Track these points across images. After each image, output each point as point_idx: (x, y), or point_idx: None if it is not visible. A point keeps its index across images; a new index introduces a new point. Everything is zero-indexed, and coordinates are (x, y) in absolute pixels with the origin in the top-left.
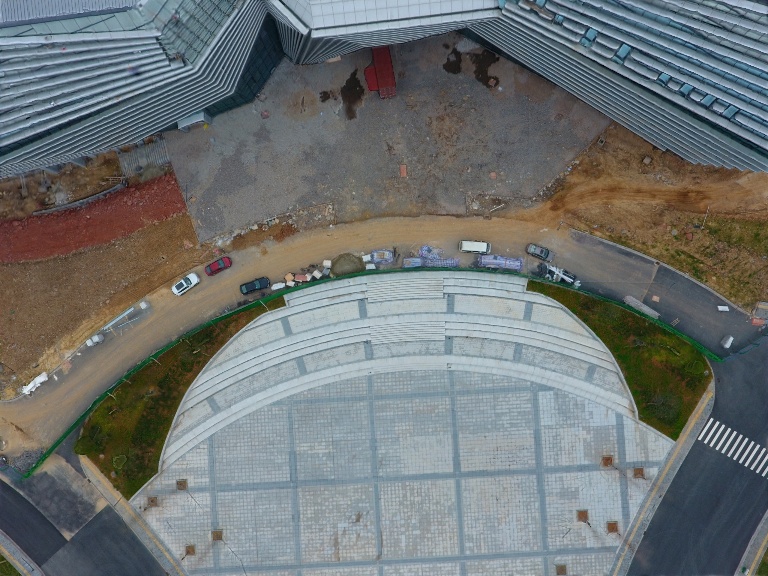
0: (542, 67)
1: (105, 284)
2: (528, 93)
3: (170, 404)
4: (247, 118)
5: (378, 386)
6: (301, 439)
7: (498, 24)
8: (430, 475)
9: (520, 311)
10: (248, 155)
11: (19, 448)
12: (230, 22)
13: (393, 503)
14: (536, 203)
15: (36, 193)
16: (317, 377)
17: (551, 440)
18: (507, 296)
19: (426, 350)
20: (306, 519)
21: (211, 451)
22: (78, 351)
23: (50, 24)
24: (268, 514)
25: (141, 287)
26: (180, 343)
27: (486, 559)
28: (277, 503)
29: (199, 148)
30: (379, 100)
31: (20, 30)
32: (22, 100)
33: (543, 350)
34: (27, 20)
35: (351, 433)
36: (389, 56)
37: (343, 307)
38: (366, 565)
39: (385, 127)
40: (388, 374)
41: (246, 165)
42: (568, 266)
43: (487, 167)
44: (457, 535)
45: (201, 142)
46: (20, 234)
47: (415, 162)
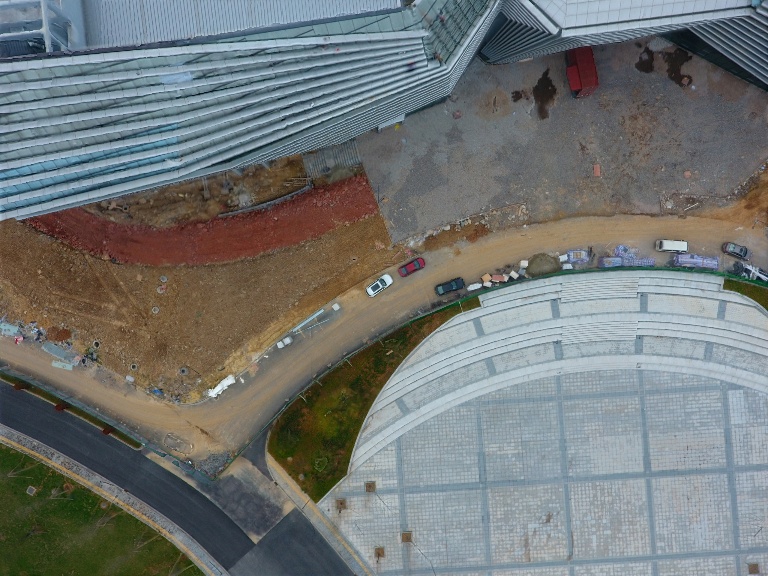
0: (760, 65)
1: (295, 286)
2: (721, 92)
3: (362, 406)
4: (439, 118)
5: (567, 386)
6: (490, 440)
7: (739, 22)
8: (620, 475)
9: (714, 310)
10: (440, 155)
11: (205, 451)
12: (482, 22)
13: (583, 503)
14: (731, 202)
15: (218, 195)
16: (507, 378)
17: (741, 439)
18: (701, 295)
19: (616, 350)
20: (496, 520)
21: (399, 453)
22: (265, 353)
23: (329, 25)
24: (457, 515)
25: (331, 289)
26: (372, 345)
27: (678, 558)
28: (466, 504)
29: (391, 149)
30: (571, 99)
31: (301, 31)
32: (285, 102)
33: (734, 349)
34: (309, 21)
35: (540, 433)
36: (592, 55)
37: (535, 307)
38: (557, 565)
39: (578, 126)
40: (577, 374)
41: (438, 165)
42: (763, 264)
43: (681, 166)
44: (648, 535)
45: (393, 143)
46: (205, 236)
47: (608, 161)
